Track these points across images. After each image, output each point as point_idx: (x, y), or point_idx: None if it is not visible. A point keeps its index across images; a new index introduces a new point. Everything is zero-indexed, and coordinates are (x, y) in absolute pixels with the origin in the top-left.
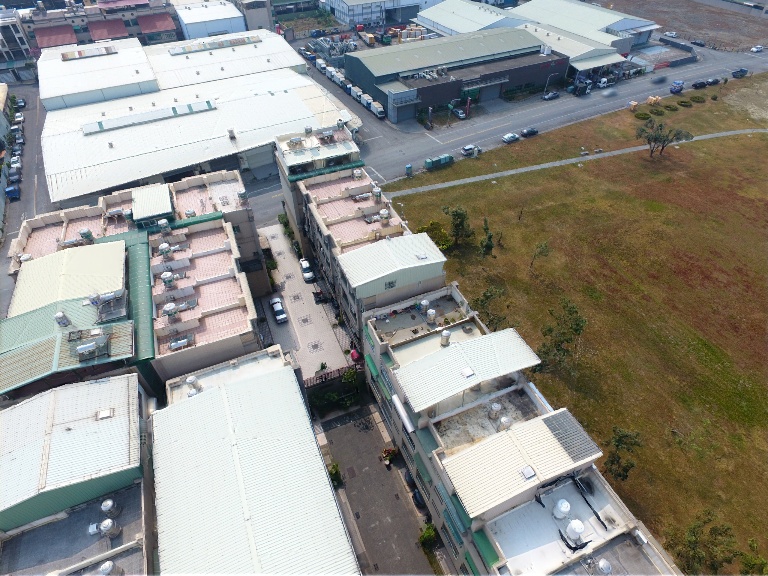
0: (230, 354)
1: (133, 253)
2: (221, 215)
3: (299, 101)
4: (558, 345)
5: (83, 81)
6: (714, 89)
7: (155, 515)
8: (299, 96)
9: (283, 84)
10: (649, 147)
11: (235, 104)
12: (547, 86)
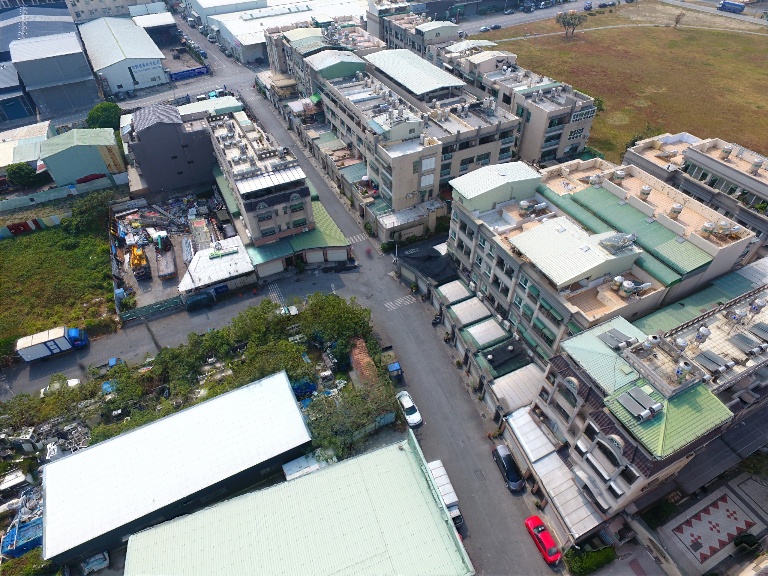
0: None
1: None
2: (354, 25)
3: (359, 7)
4: None
5: (223, 0)
6: (612, 8)
7: None
8: (358, 5)
9: (345, 1)
10: (565, 31)
11: (322, 8)
12: (506, 5)
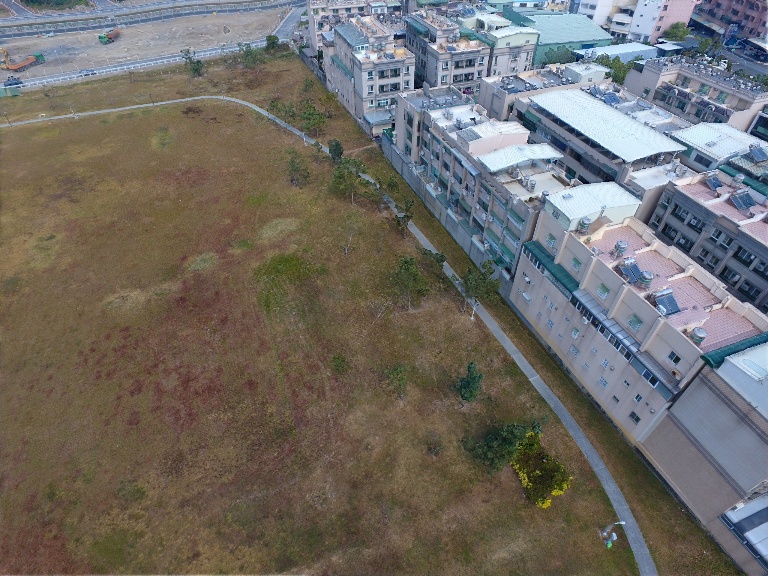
0: None
1: None
2: None
3: None
4: None
5: None
6: None
7: None
8: None
9: None
10: None
11: None
12: None
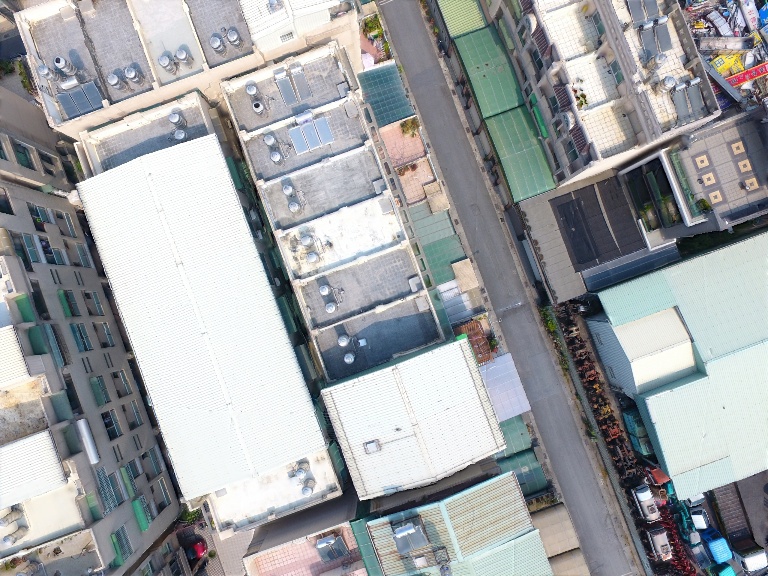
0: (282, 530)
1: None
2: None
3: None
4: None
5: None
6: None
7: (313, 351)
8: None
9: None
10: None
11: None
12: None
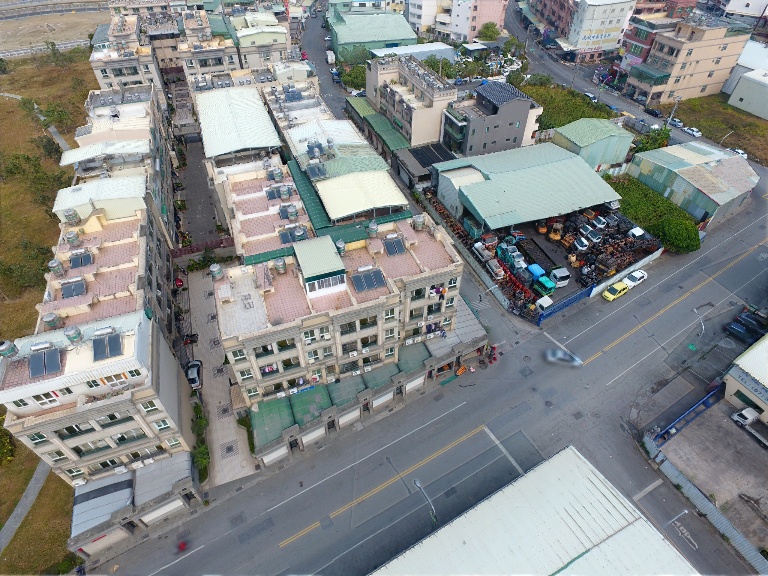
0: None
1: (324, 219)
2: None
3: None
4: (8, 270)
5: None
6: None
7: None
8: None
9: None
10: None
11: None
12: None
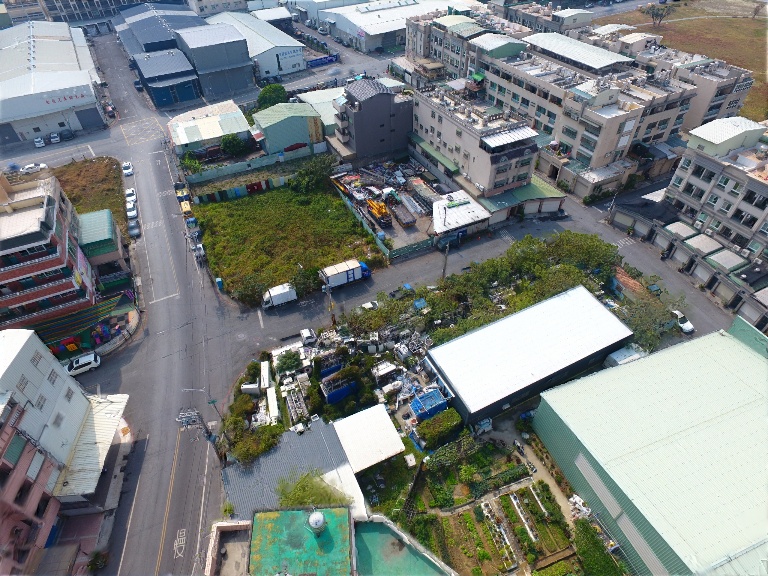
0: None
1: None
2: None
3: (460, 1)
4: None
5: None
6: (685, 1)
7: None
8: None
9: None
10: None
11: (427, 2)
12: None
